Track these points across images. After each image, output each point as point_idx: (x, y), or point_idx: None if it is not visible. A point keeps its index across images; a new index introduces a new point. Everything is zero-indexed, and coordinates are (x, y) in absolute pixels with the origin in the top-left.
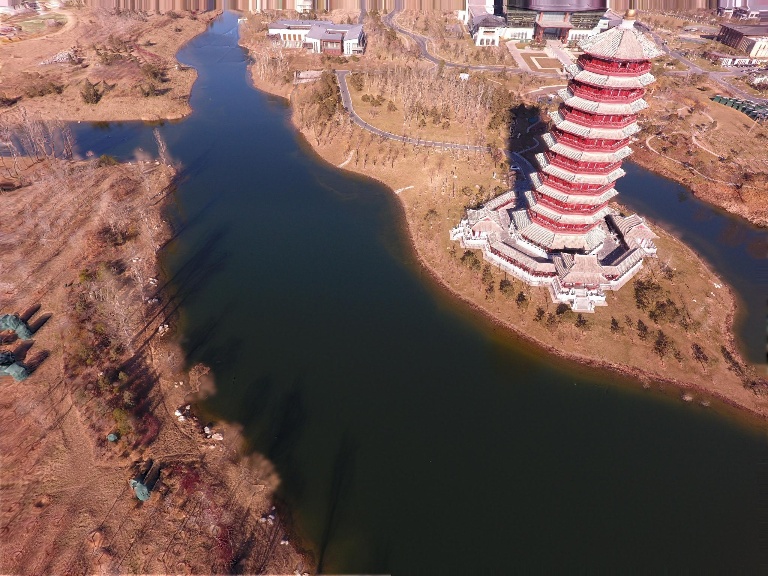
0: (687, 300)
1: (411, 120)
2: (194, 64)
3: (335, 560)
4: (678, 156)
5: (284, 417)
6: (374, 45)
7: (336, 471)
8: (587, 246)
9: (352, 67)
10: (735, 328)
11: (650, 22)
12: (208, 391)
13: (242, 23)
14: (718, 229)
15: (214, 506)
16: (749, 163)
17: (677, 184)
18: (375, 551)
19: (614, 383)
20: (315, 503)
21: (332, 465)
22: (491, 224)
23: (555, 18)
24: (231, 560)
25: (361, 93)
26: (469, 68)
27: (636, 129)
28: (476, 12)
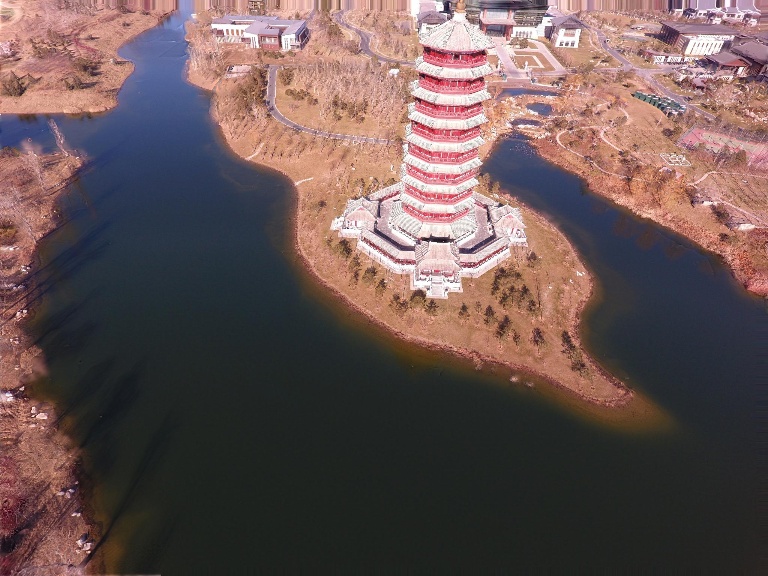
0: (543, 287)
1: (328, 114)
2: (134, 58)
3: (123, 531)
4: (582, 150)
5: (115, 398)
6: (316, 41)
7: (150, 448)
8: (452, 235)
9: (287, 62)
10: (585, 314)
11: (598, 20)
12: (51, 374)
13: (189, 18)
14: (613, 221)
15: (14, 480)
16: (646, 157)
17: (576, 177)
18: (165, 522)
19: (450, 365)
20: (122, 478)
21: (148, 442)
22: (365, 214)
23: (499, 15)
24: (13, 530)
25: (288, 87)
26: (405, 64)
27: (483, 120)
28: (424, 9)
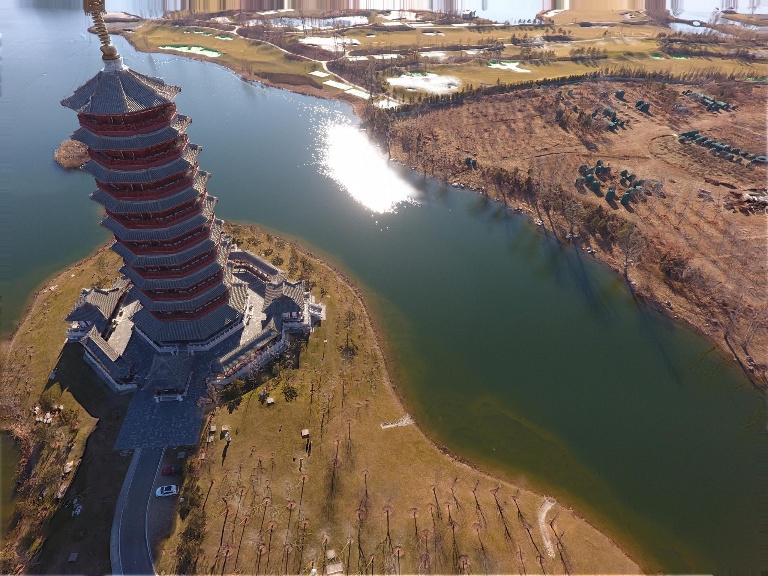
0: None
1: None
2: None
3: (383, 165)
4: None
5: (427, 193)
6: None
7: None
8: None
9: None
10: None
11: None
12: None
13: None
14: None
15: None
16: None
17: None
18: (368, 168)
19: None
20: (397, 176)
21: (394, 182)
22: None
23: None
24: None
25: None
26: None
27: None
28: None
